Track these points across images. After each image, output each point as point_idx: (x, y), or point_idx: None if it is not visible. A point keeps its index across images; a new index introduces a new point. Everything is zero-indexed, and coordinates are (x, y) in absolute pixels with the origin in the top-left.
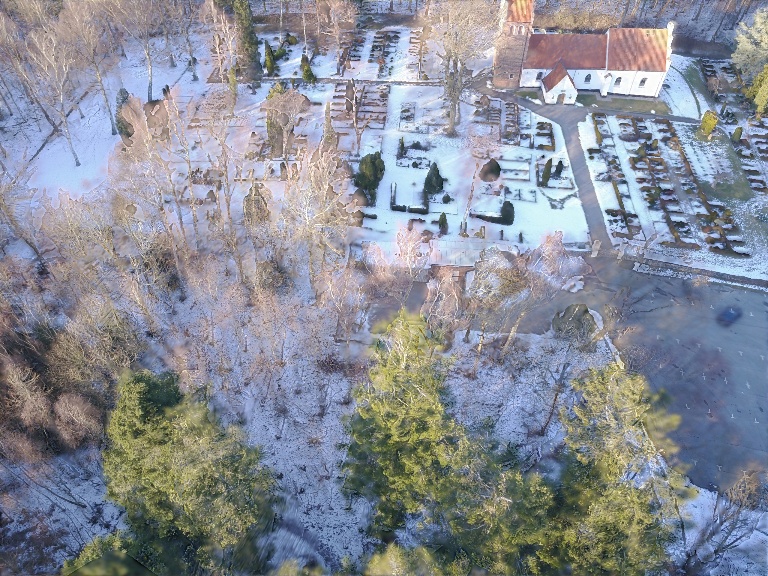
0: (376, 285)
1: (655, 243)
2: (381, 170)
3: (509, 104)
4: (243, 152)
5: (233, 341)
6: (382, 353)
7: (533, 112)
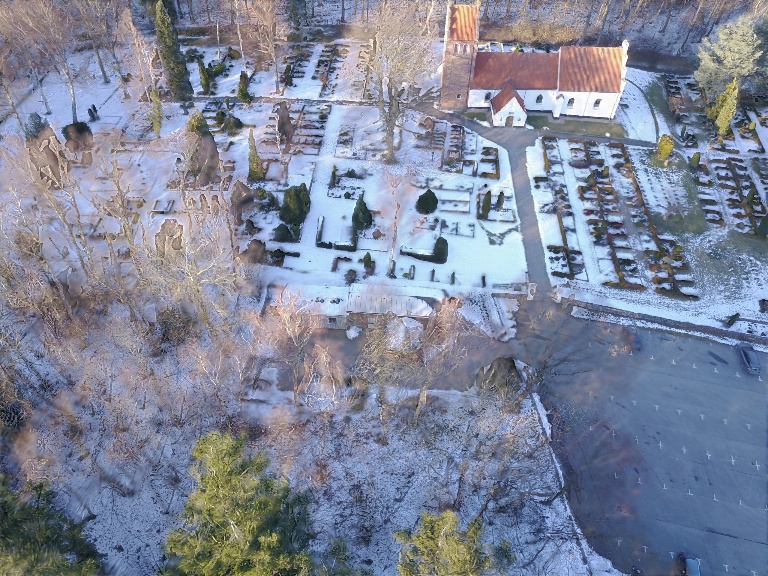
0: (257, 355)
1: (598, 283)
2: (306, 203)
3: (455, 127)
4: (166, 180)
5: (131, 397)
6: (203, 475)
7: (480, 135)
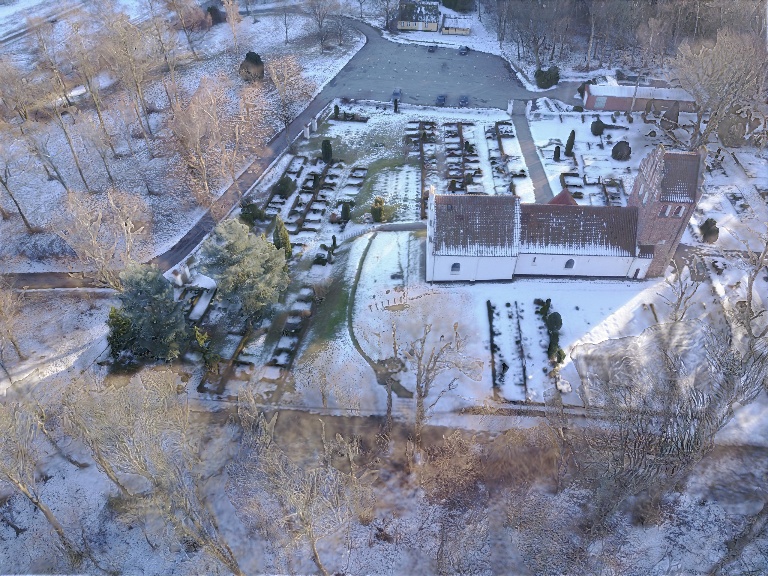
0: None
1: (478, 125)
2: None
3: None
4: None
5: None
6: None
7: None
